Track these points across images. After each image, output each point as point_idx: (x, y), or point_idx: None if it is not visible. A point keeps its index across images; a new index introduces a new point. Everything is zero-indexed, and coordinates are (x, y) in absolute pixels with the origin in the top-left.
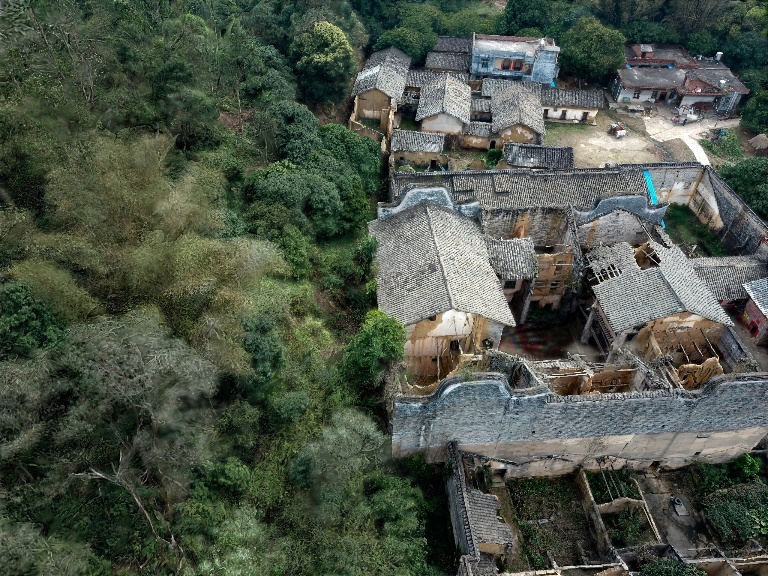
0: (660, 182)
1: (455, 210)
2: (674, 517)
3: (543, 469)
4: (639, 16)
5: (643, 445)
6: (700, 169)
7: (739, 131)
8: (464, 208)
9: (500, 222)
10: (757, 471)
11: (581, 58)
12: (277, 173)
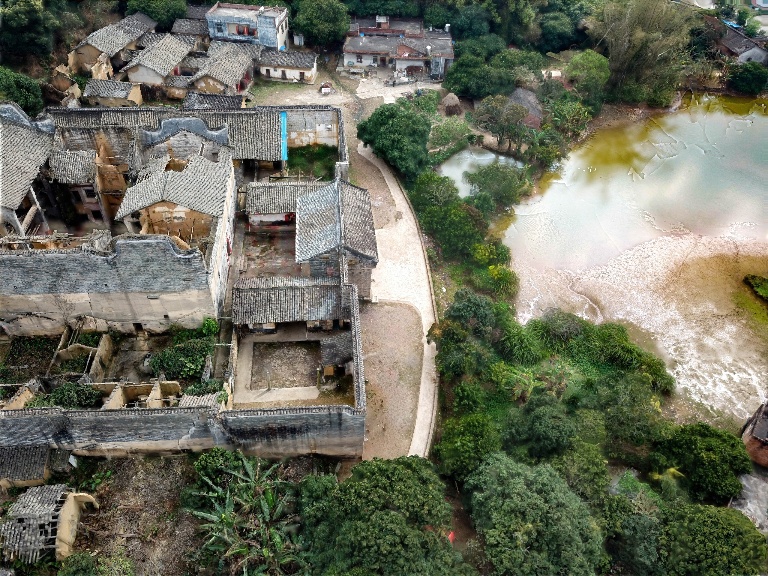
0: (302, 124)
1: (33, 127)
2: (139, 367)
3: (36, 327)
4: None
5: (107, 305)
6: (333, 112)
7: (445, 92)
8: (41, 125)
9: (81, 139)
10: (212, 331)
11: (304, 25)
12: None
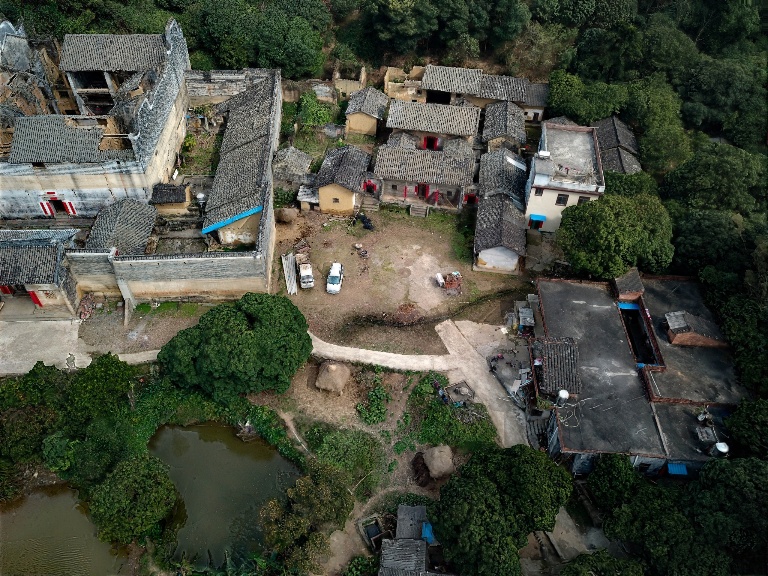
0: None
1: None
2: None
3: None
4: (763, 298)
5: None
6: None
7: None
8: None
9: None
10: None
11: None
12: (232, 1)
